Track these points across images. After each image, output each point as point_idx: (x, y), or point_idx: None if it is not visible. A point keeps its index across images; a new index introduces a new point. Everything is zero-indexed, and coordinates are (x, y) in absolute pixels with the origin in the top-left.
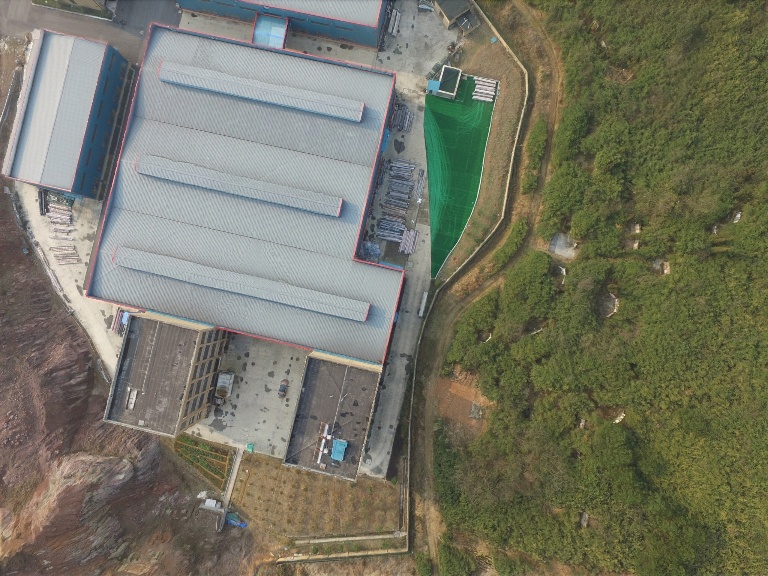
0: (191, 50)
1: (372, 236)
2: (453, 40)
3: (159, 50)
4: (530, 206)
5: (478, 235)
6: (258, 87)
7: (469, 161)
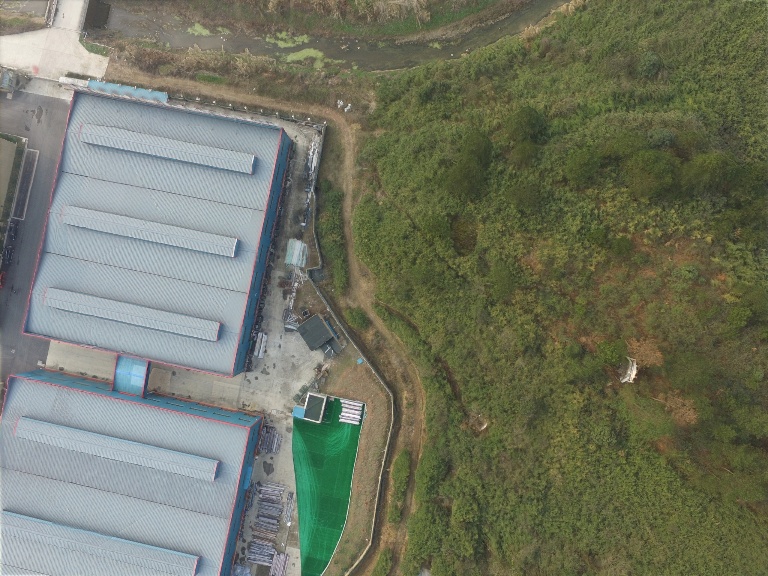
0: (50, 400)
1: (243, 559)
2: (320, 360)
3: (18, 400)
4: (396, 536)
5: (347, 561)
6: (112, 447)
7: (337, 483)
